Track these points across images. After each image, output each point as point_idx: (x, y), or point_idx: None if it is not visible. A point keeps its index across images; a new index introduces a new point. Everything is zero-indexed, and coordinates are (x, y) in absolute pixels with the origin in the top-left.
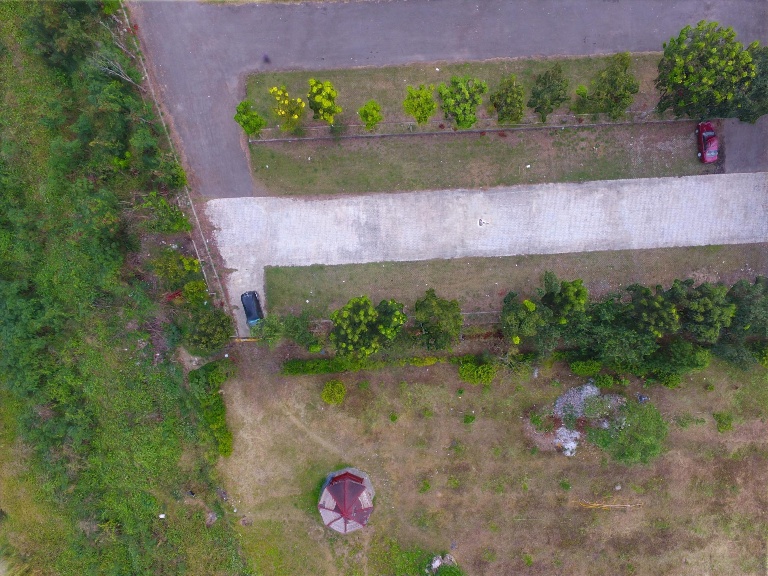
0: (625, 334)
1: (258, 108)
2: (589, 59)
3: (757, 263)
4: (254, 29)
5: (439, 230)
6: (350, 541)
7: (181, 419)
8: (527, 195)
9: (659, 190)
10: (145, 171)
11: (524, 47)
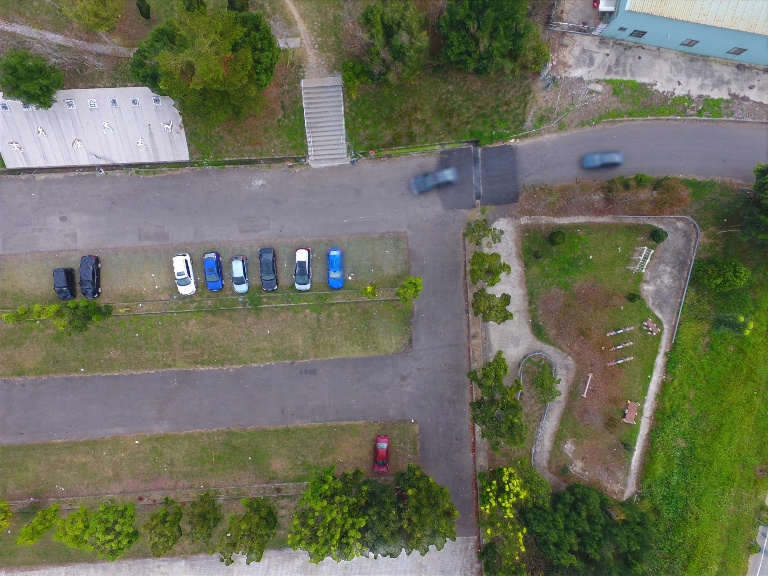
0: None
1: None
2: (287, 430)
3: None
4: None
5: None
6: None
7: None
8: None
9: None
10: None
11: (223, 419)
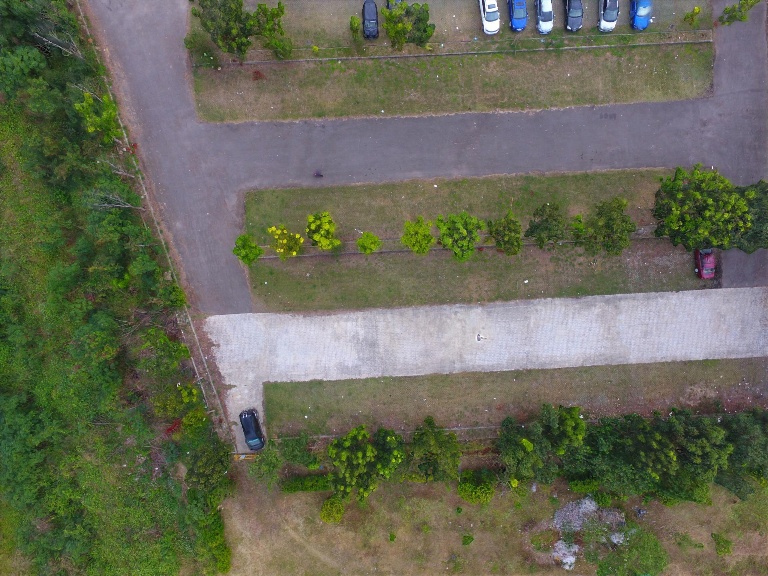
0: (623, 469)
1: (257, 225)
2: (586, 175)
3: (754, 377)
4: (253, 147)
5: (437, 345)
6: None
7: (180, 533)
8: (525, 310)
9: (656, 305)
10: (144, 289)
11: (522, 163)
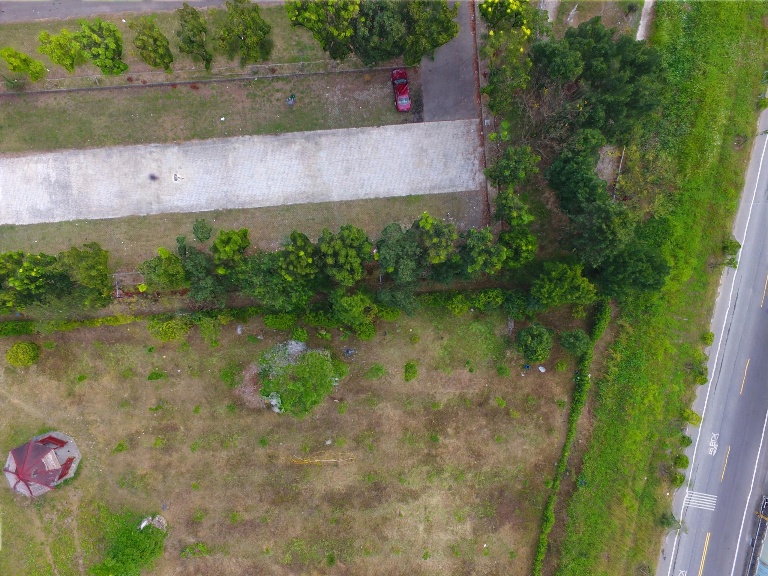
0: (273, 281)
1: None
2: (281, 8)
3: (459, 212)
4: None
5: (133, 186)
6: (58, 506)
7: None
8: (223, 148)
9: (358, 140)
10: None
11: None
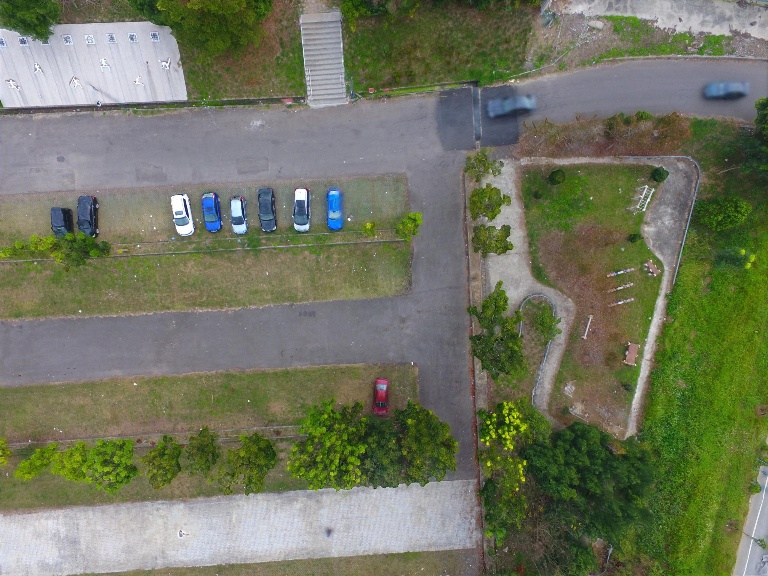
0: None
1: None
2: (286, 372)
3: (455, 569)
4: None
5: (139, 542)
6: None
7: None
8: (227, 506)
9: (358, 499)
10: None
11: (221, 361)
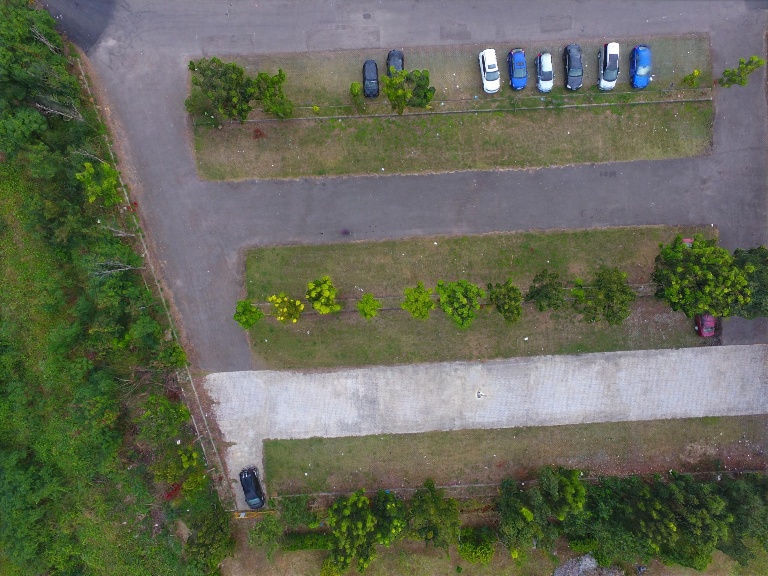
0: (623, 537)
1: (257, 282)
2: (586, 233)
3: (754, 435)
4: (253, 205)
5: (437, 402)
6: None
7: None
8: (525, 367)
9: (656, 362)
10: (144, 347)
11: (522, 221)
